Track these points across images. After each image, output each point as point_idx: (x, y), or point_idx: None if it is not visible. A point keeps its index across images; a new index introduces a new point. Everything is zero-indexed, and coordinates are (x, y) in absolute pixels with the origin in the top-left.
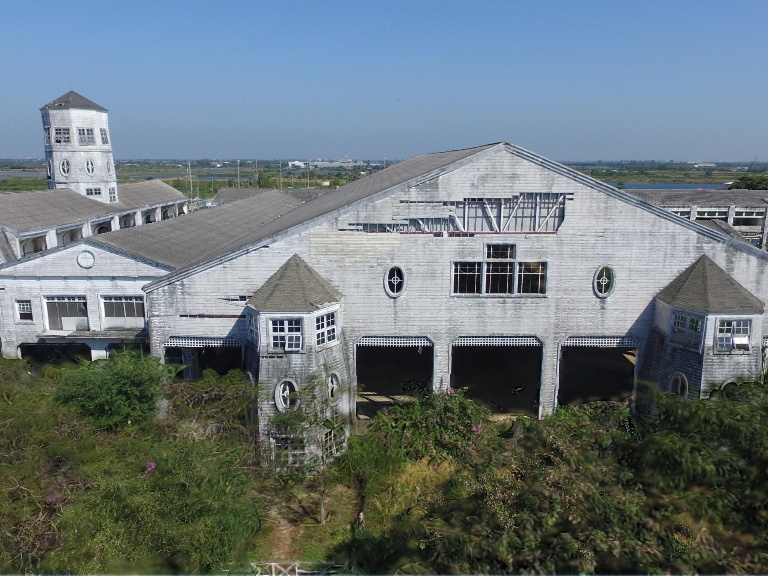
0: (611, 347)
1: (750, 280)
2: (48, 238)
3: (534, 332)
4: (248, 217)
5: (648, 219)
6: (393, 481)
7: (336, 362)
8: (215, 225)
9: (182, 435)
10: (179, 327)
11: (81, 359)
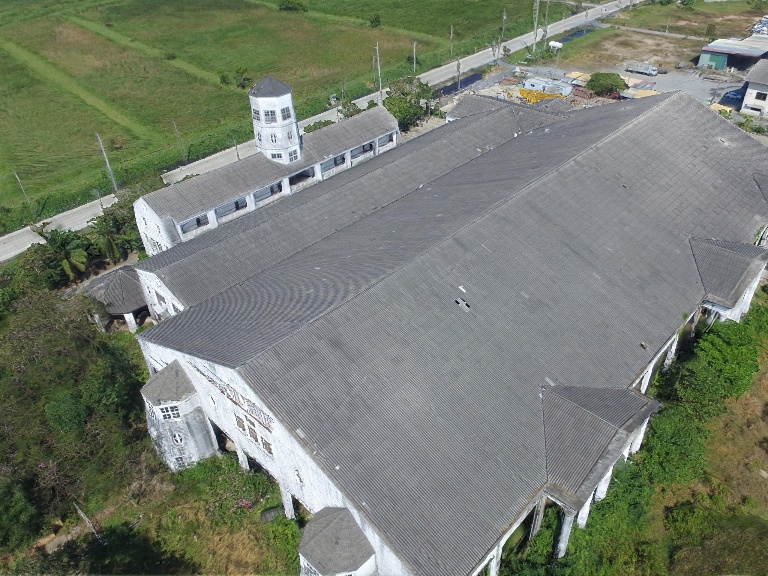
0: (311, 512)
1: (377, 545)
2: (208, 216)
3: (274, 474)
4: (371, 198)
5: (313, 463)
6: (182, 503)
7: (181, 428)
8: (306, 225)
9: (62, 454)
10: (151, 360)
11: None
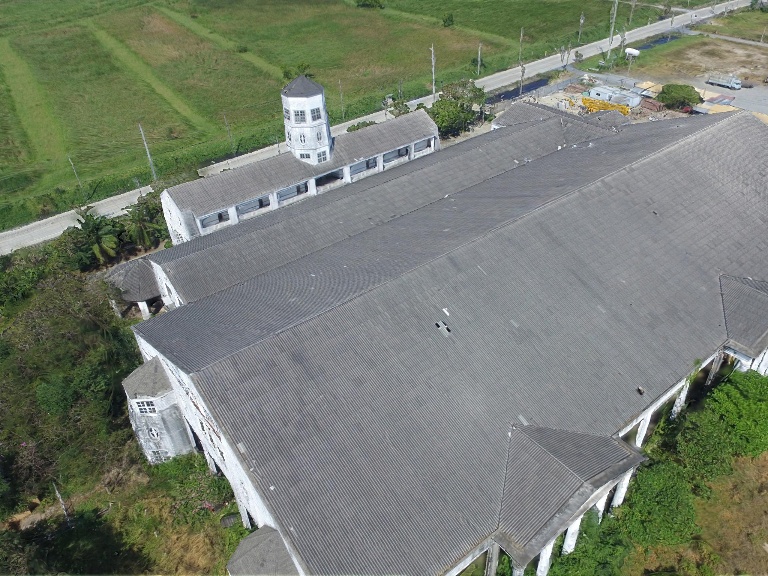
0: None
1: None
2: (229, 212)
3: None
4: (391, 205)
5: None
6: None
7: (156, 423)
8: (320, 228)
9: (44, 435)
10: None
11: (82, 361)
